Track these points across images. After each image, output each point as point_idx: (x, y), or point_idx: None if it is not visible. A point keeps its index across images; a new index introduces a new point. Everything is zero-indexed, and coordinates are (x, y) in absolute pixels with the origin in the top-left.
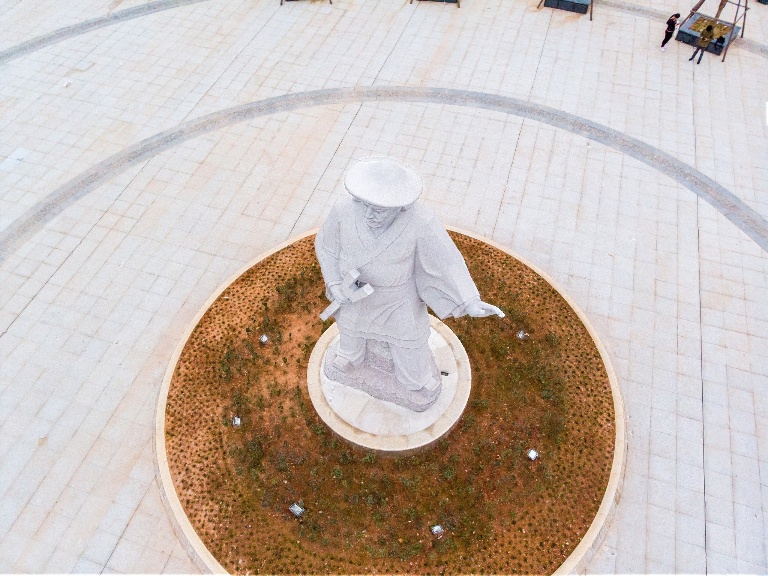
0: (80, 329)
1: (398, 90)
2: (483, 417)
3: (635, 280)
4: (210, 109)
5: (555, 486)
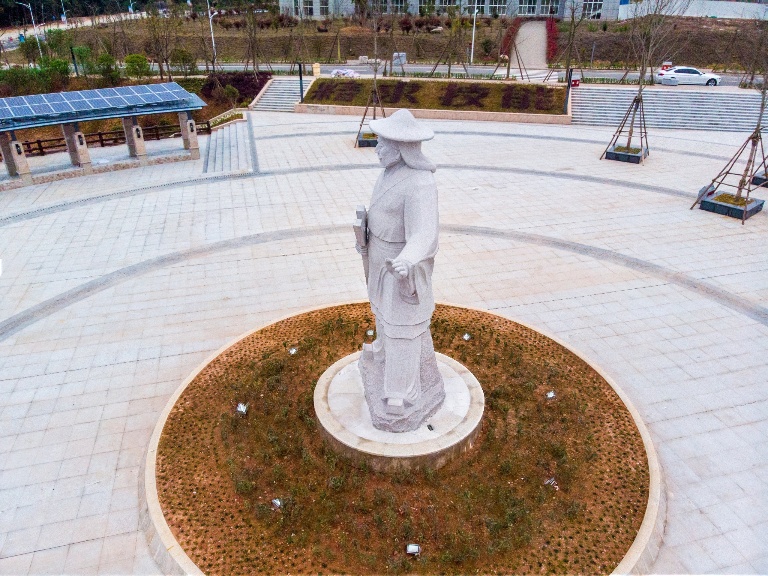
0: (310, 274)
1: (721, 293)
2: (421, 490)
3: None
4: (540, 232)
5: None
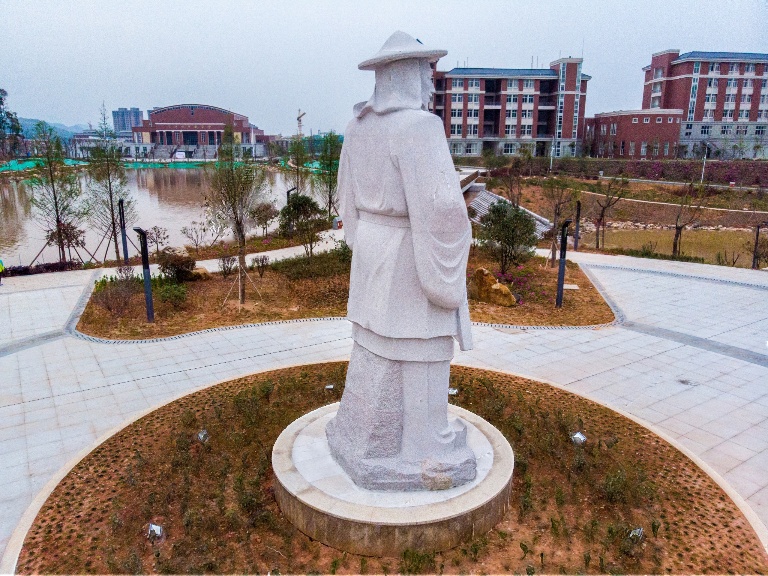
0: None
1: None
2: None
3: (4, 440)
4: None
5: (339, 376)
